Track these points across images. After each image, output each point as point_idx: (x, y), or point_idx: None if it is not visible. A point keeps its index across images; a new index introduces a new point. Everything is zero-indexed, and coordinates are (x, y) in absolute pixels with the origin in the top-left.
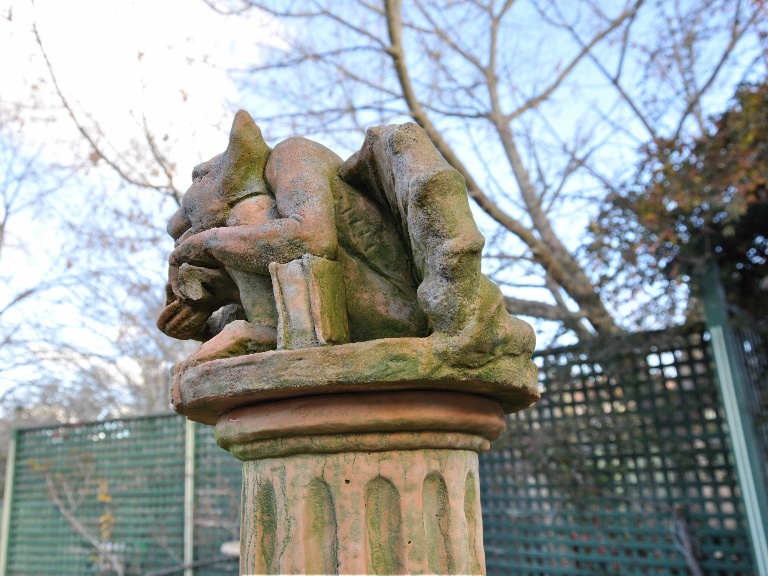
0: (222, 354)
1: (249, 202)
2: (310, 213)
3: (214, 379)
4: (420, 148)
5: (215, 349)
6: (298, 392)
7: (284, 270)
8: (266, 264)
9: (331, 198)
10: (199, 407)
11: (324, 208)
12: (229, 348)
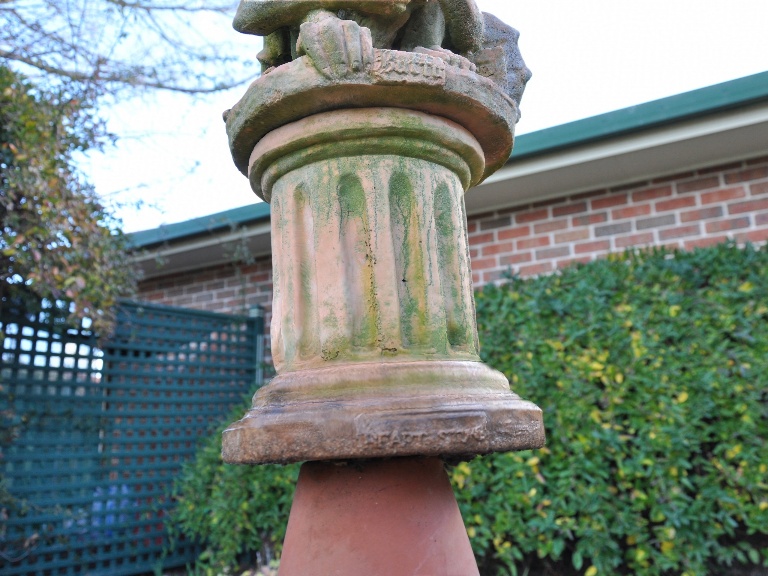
0: None
1: None
2: None
3: None
4: None
5: None
6: (488, 137)
7: None
8: (472, 34)
9: None
10: (440, 97)
11: None
12: None
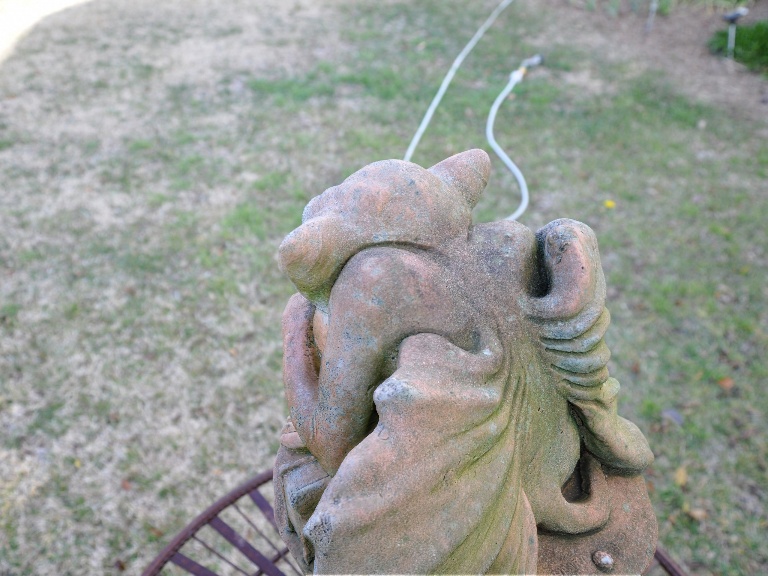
0: (295, 450)
1: (321, 319)
2: (322, 432)
3: None
4: (329, 567)
5: (289, 445)
6: None
7: (285, 486)
8: None
9: (360, 406)
10: None
11: (341, 427)
12: (300, 448)
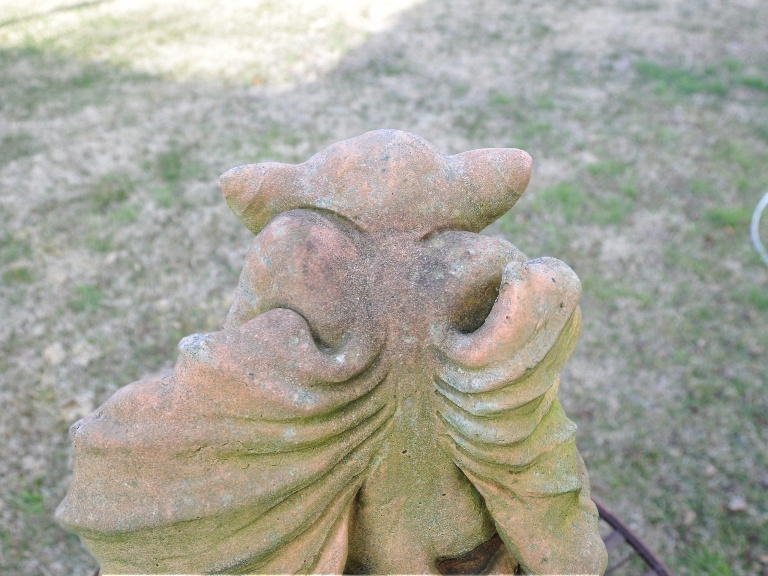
0: None
1: None
2: None
3: None
4: (75, 469)
5: None
6: None
7: None
8: None
9: None
10: None
11: None
12: None
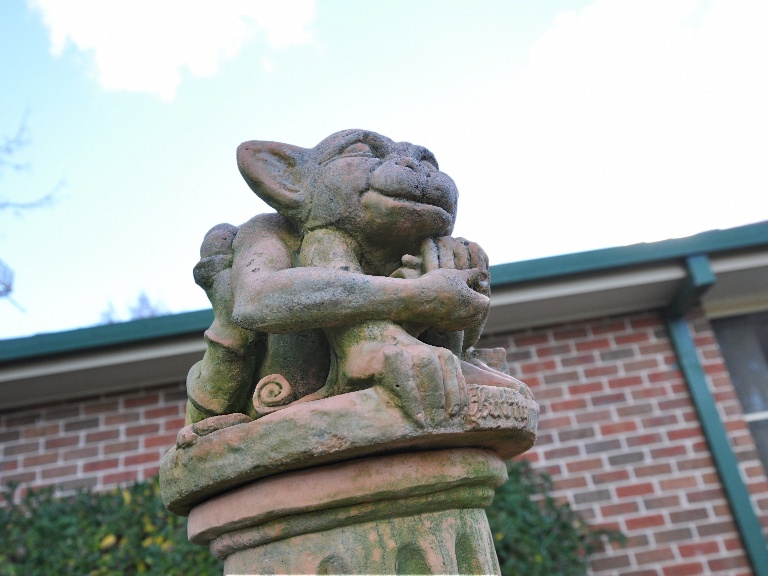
0: None
1: None
2: None
3: None
4: None
5: None
6: None
7: None
8: None
9: None
10: (511, 436)
11: None
12: None
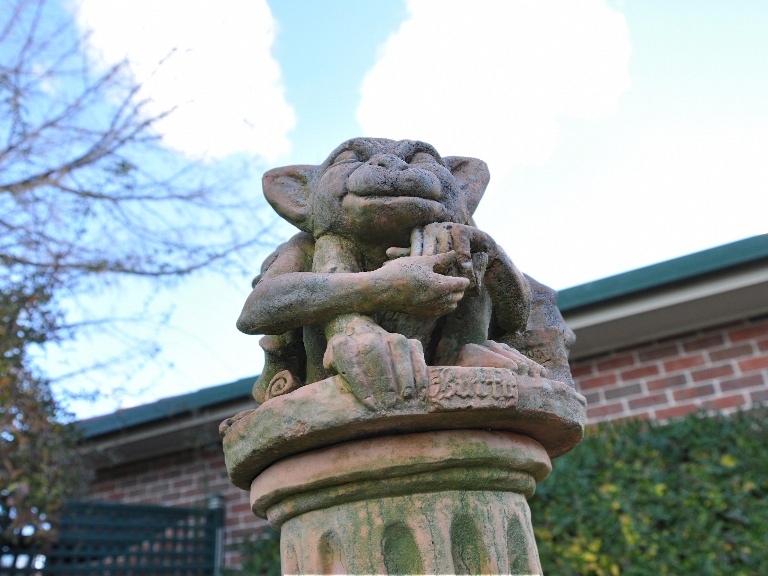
0: None
1: None
2: None
3: (565, 401)
4: None
5: None
6: (553, 438)
7: None
8: (522, 314)
9: None
10: (509, 416)
11: None
12: None
